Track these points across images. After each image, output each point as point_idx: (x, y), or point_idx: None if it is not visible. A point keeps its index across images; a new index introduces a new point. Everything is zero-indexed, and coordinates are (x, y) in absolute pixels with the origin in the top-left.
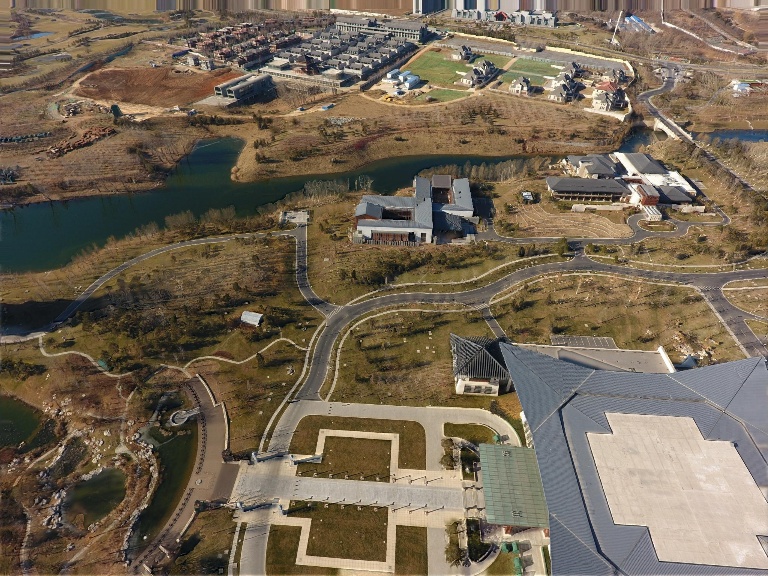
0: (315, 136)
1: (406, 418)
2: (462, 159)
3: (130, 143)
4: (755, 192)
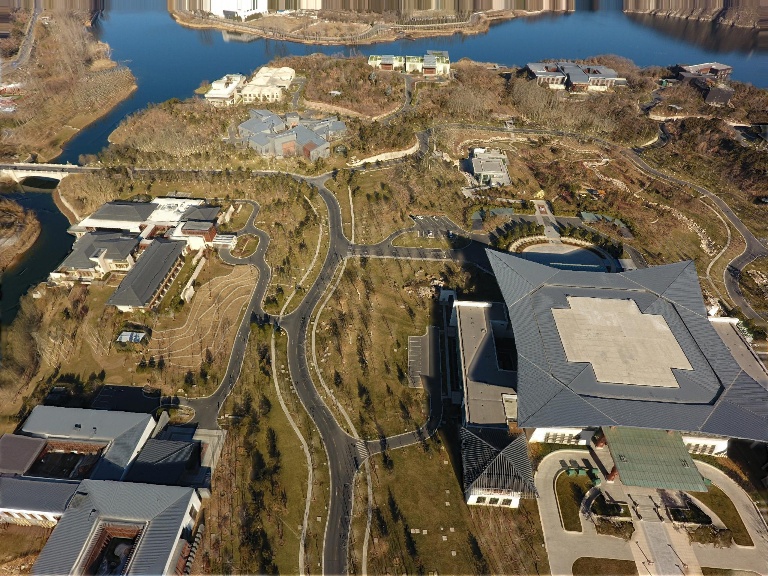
0: None
1: None
2: None
3: None
4: (222, 171)
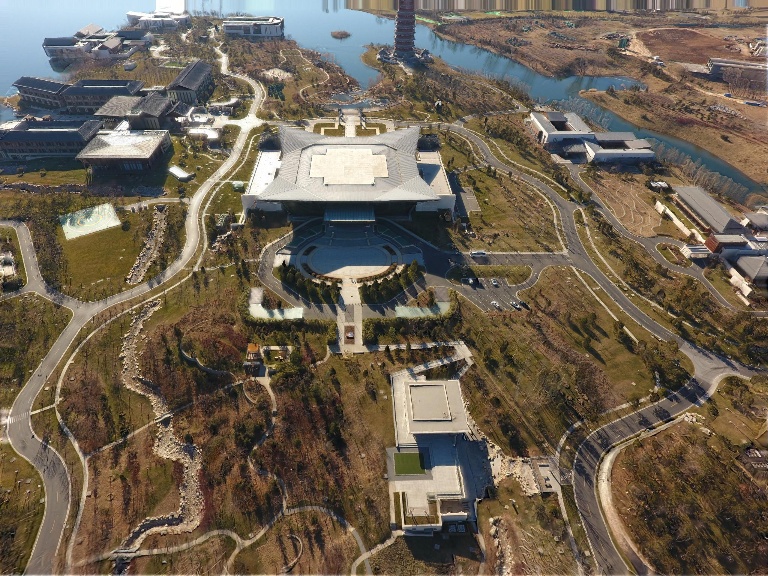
0: (674, 102)
1: None
2: (740, 179)
3: None
4: None
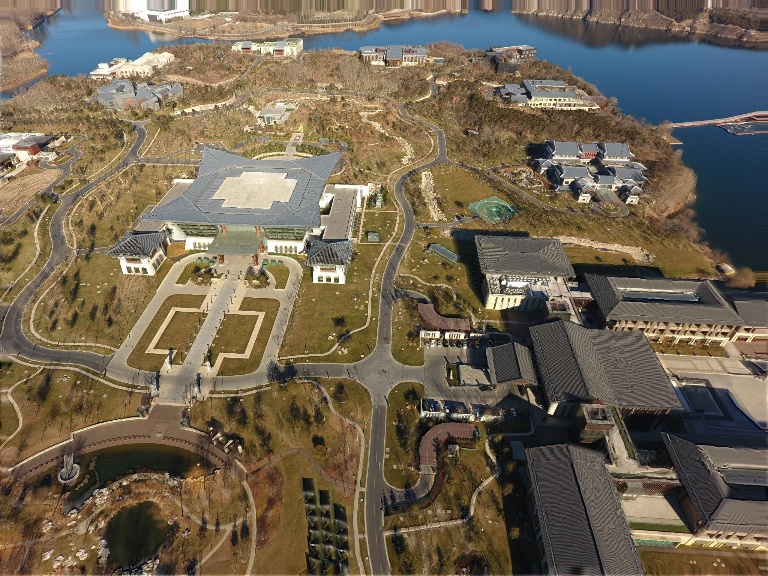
0: None
1: (161, 303)
2: None
3: None
4: None
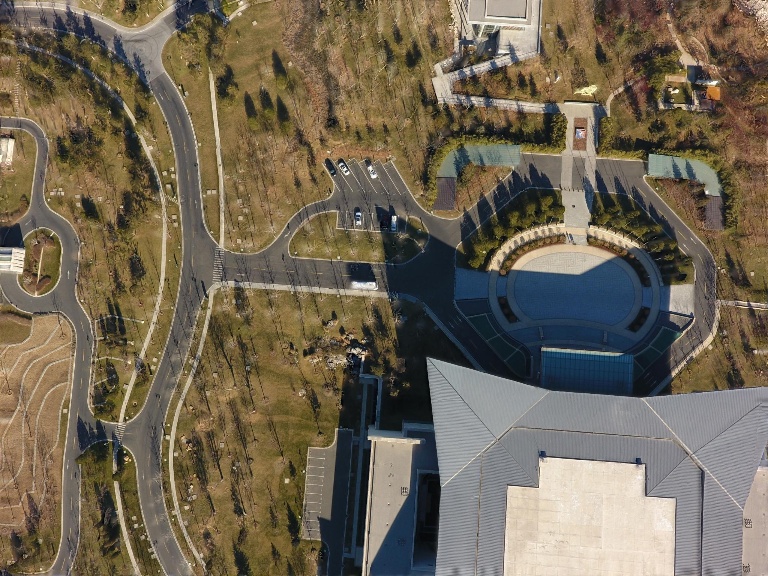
0: None
1: None
2: None
3: None
4: None
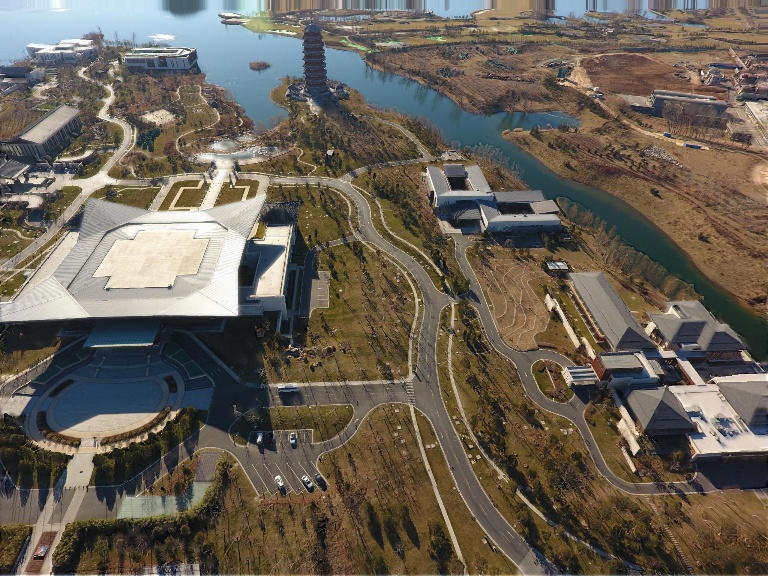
0: (603, 146)
1: None
2: (667, 247)
3: (524, 90)
4: None
